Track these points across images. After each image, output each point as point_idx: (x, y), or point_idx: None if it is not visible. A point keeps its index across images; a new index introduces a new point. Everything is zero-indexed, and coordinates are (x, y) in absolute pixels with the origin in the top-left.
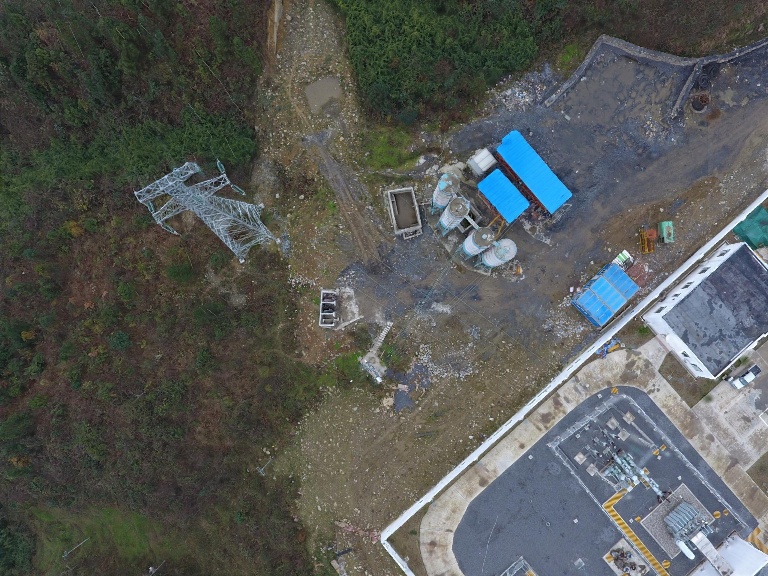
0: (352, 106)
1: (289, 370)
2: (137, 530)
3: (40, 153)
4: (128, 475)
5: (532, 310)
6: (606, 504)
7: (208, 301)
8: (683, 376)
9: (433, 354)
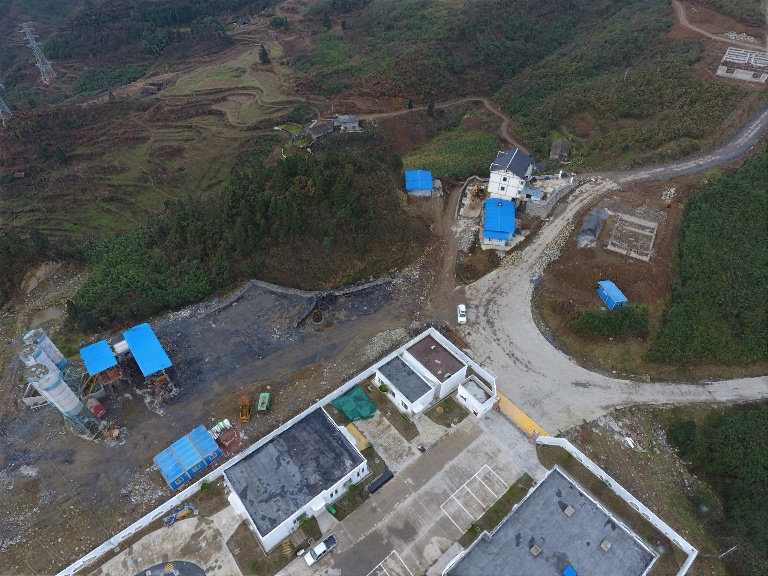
0: (61, 322)
1: None
2: None
3: None
4: None
5: (118, 474)
6: None
7: None
8: (253, 550)
9: None
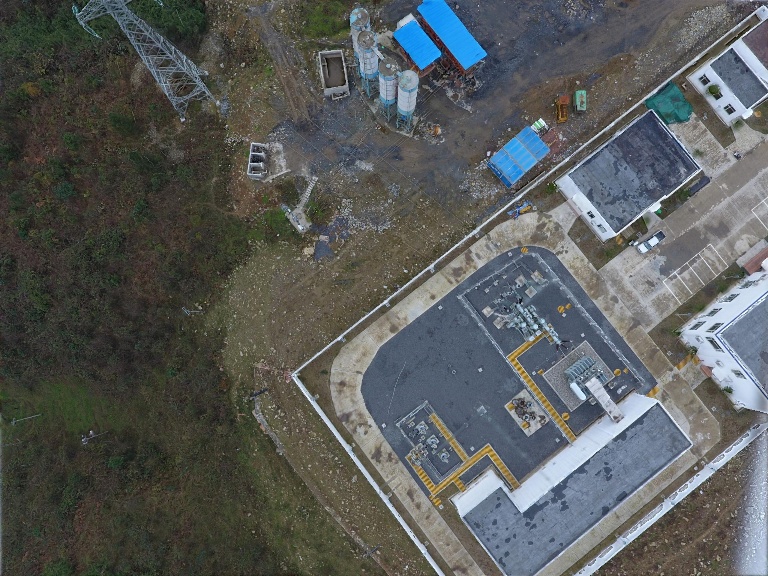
0: None
1: (221, 223)
2: (84, 404)
3: (8, 27)
4: (67, 322)
5: (450, 171)
6: (510, 356)
7: (147, 152)
8: (591, 240)
9: (354, 208)
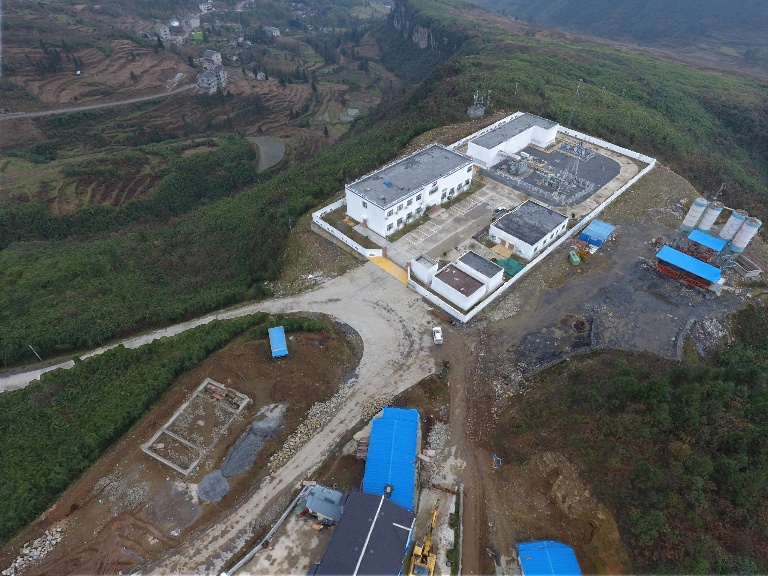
0: None
1: None
2: None
3: None
4: None
5: None
6: None
7: None
8: None
9: None
